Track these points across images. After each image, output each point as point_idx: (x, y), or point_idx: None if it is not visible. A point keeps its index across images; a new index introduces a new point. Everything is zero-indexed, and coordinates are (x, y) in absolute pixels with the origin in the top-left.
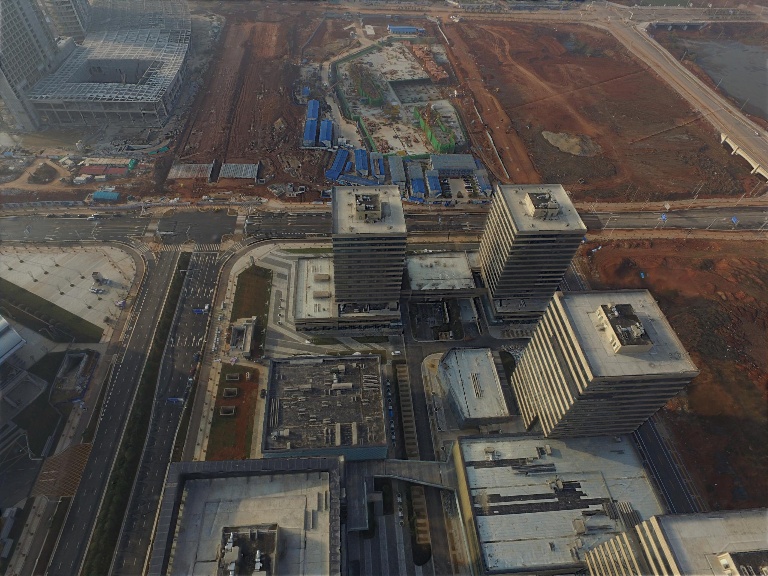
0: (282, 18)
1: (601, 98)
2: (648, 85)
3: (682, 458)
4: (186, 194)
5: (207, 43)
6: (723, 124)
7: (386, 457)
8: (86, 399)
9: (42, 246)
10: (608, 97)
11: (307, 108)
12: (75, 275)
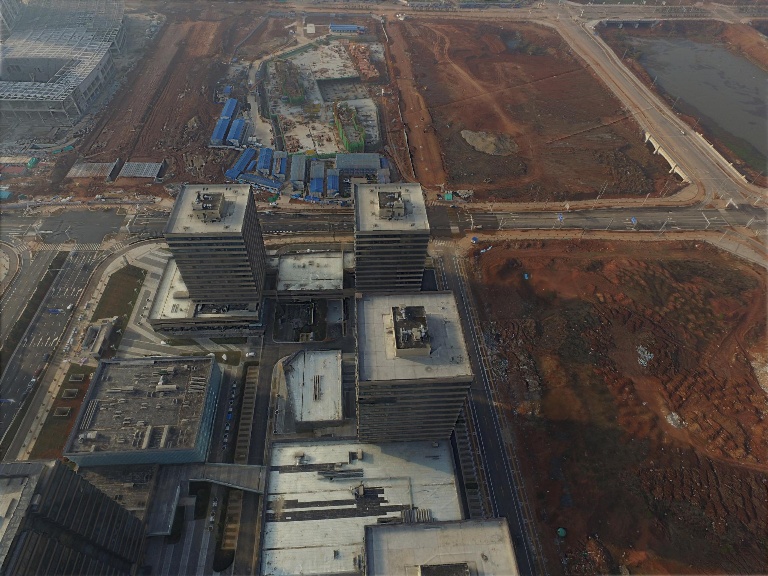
0: (224, 17)
1: (531, 97)
2: (583, 83)
3: (520, 464)
4: (80, 193)
5: (141, 42)
6: (650, 123)
7: (205, 460)
8: None
9: None
10: (539, 96)
11: None
12: None
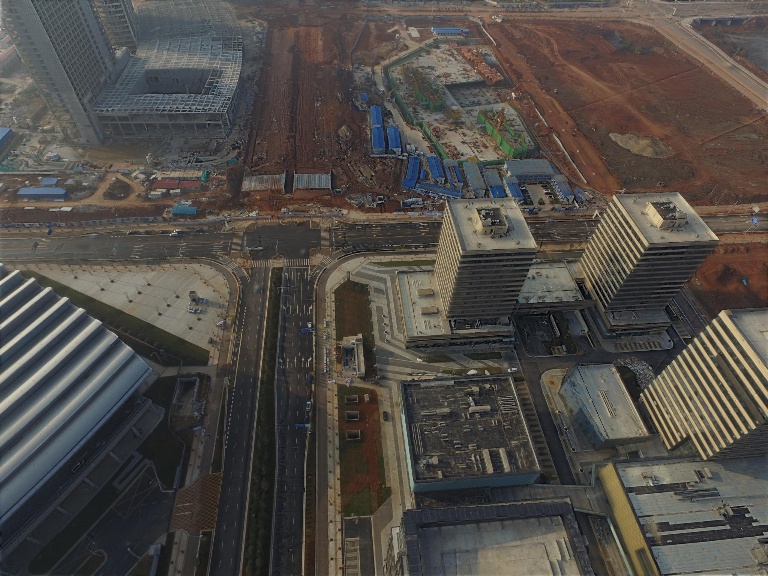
0: (324, 22)
1: (661, 97)
2: (705, 83)
3: None
4: (264, 207)
5: (254, 49)
6: None
7: (531, 482)
8: (206, 426)
9: (129, 265)
10: (667, 96)
11: (368, 114)
12: (169, 294)
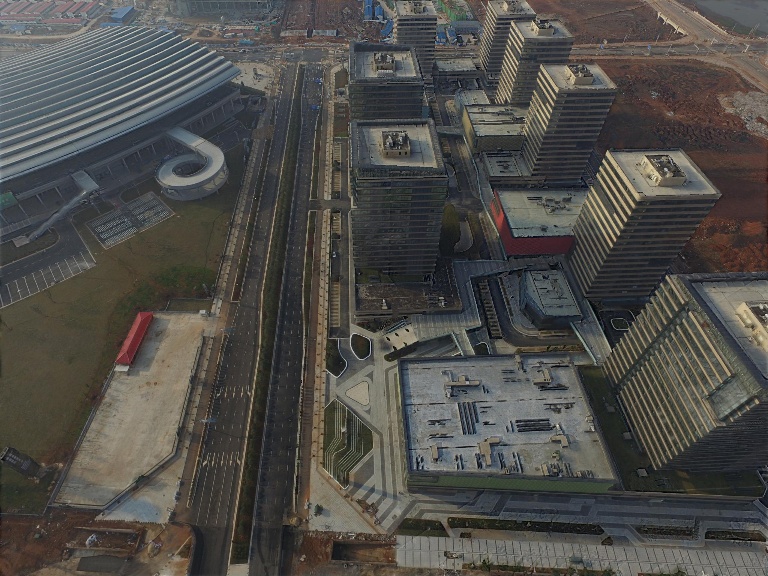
0: None
1: None
2: None
3: None
4: (294, 42)
5: None
6: (661, 7)
7: None
8: (266, 113)
9: None
10: None
11: (364, 3)
12: None
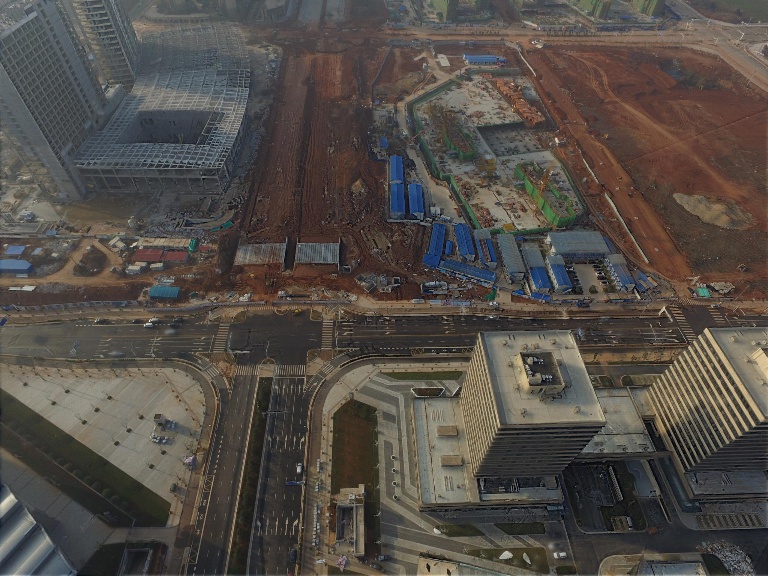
0: (344, 48)
1: (733, 145)
2: None
3: None
4: (258, 288)
5: (265, 81)
6: None
7: None
8: None
9: (91, 367)
10: (741, 144)
11: (388, 165)
12: (132, 414)
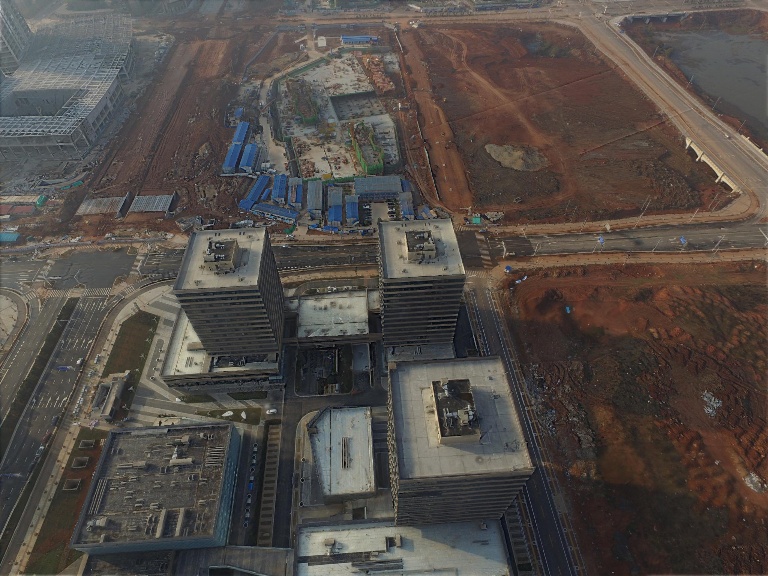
0: (233, 34)
1: (558, 104)
2: (612, 86)
3: (578, 538)
4: (90, 232)
5: (150, 65)
6: (690, 127)
7: (226, 544)
8: None
9: None
10: (566, 102)
11: None
12: None
